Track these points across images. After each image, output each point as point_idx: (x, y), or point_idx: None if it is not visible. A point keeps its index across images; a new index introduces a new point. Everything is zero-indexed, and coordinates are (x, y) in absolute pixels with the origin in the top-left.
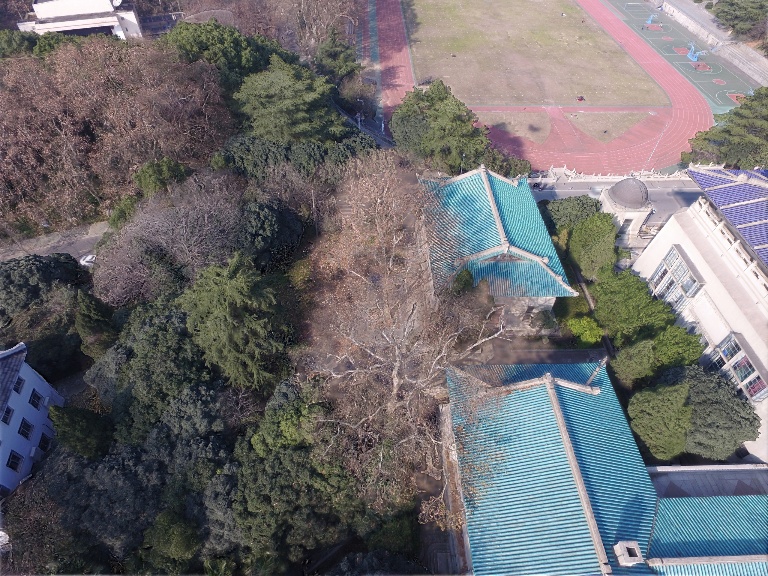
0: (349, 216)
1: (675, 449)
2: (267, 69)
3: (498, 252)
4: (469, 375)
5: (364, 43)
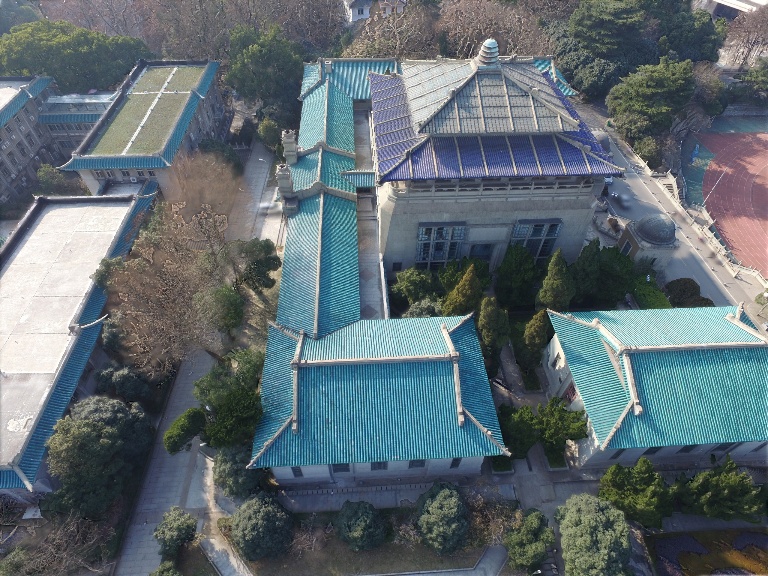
0: None
1: None
2: (622, 0)
3: None
4: None
5: None
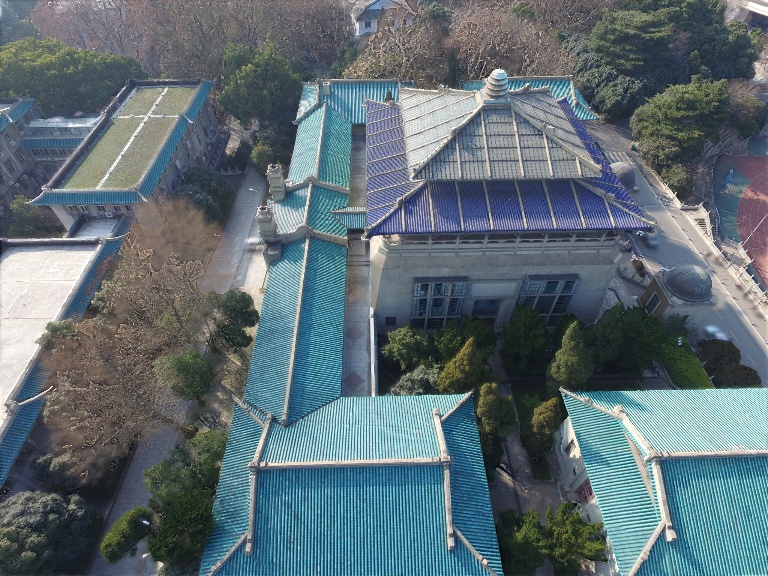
0: None
1: None
2: (650, 13)
3: None
4: (408, 81)
5: None
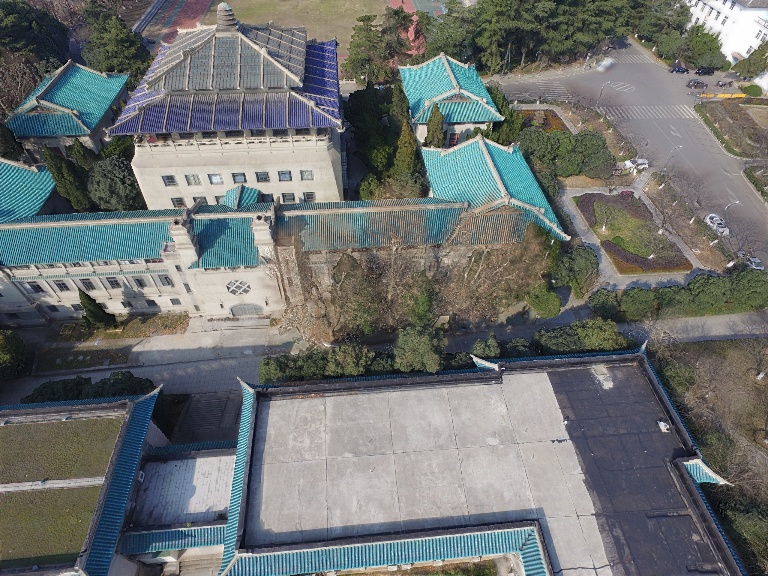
0: None
1: (82, 201)
2: None
3: (33, 105)
4: None
5: (165, 13)
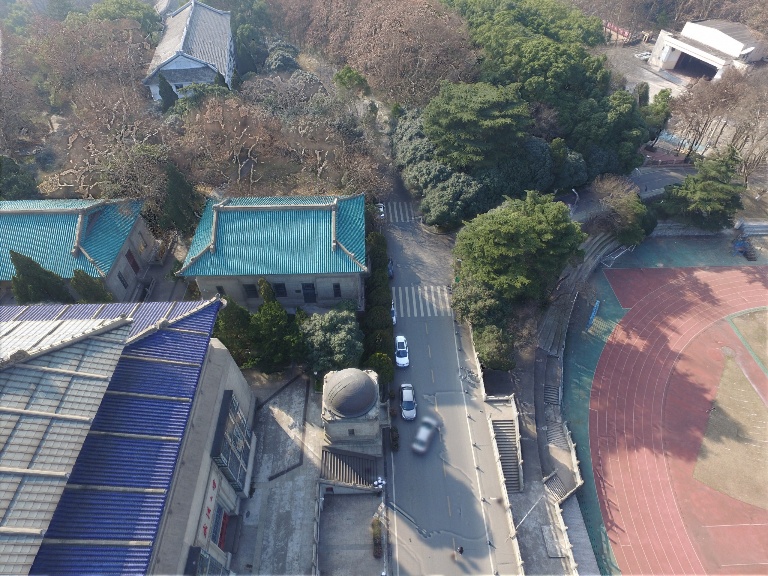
0: (396, 214)
1: None
2: None
3: None
4: (124, 199)
5: None
